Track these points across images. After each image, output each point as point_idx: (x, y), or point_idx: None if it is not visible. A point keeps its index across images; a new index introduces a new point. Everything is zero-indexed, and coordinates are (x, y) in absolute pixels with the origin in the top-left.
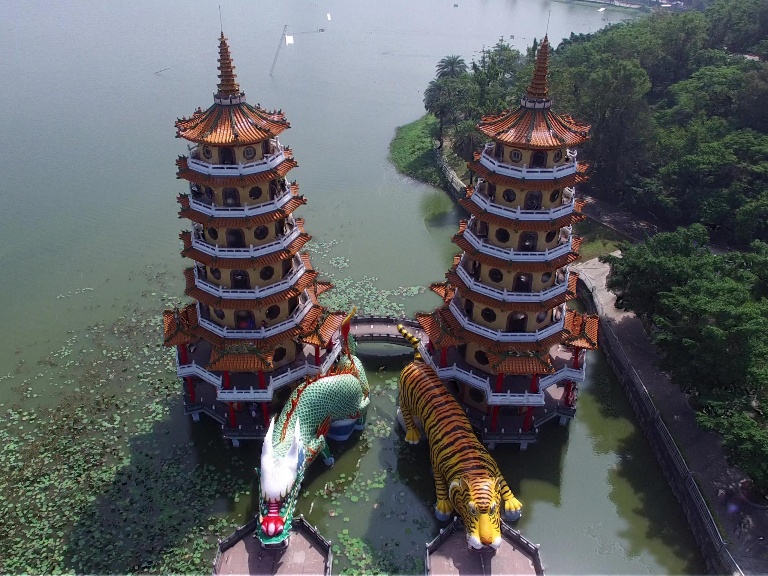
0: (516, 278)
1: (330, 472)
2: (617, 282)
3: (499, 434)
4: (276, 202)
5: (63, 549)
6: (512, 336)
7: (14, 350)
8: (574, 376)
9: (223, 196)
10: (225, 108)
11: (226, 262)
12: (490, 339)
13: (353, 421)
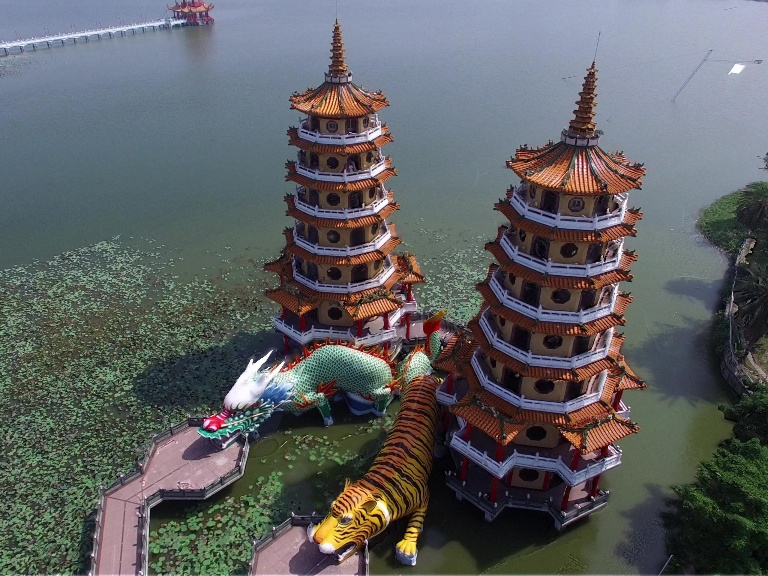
0: (516, 328)
1: (321, 429)
2: (731, 414)
3: (461, 485)
4: (345, 175)
5: (141, 372)
6: (497, 389)
7: (246, 246)
8: (566, 475)
9: (310, 158)
10: (328, 84)
11: (299, 214)
12: (479, 382)
13: (367, 401)
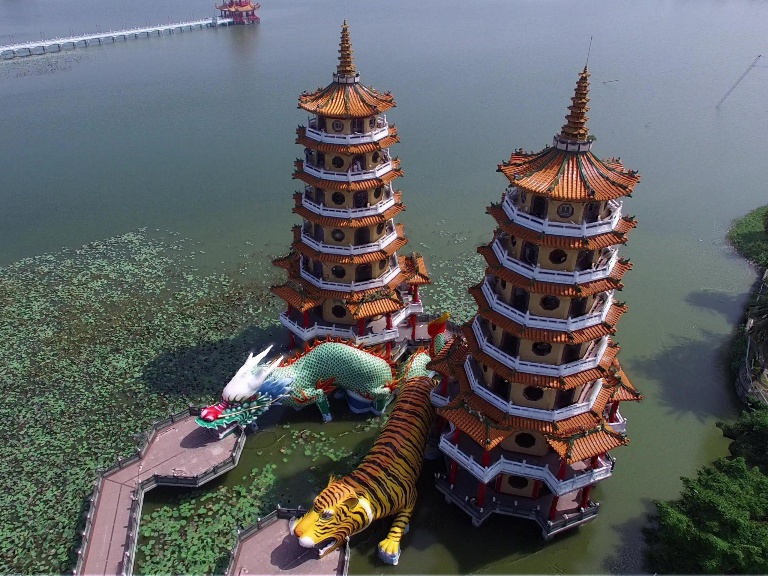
0: (506, 333)
1: (319, 425)
2: (729, 432)
3: (449, 488)
4: (349, 175)
5: (152, 360)
6: (487, 393)
7: (265, 242)
8: (552, 483)
9: (317, 157)
10: (335, 84)
11: (305, 211)
12: (470, 385)
13: (366, 400)
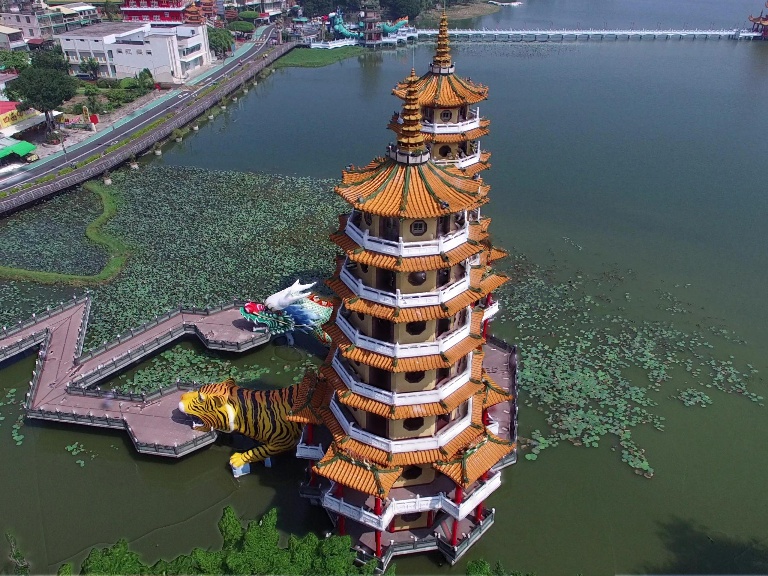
0: None
1: None
2: None
3: None
4: None
5: None
6: None
7: (489, 231)
8: None
9: None
10: None
11: None
12: None
13: None
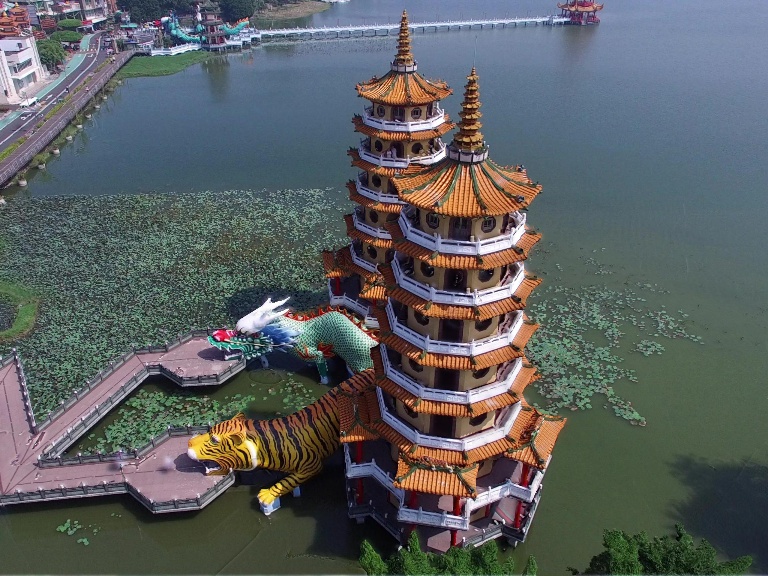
0: None
1: (315, 384)
2: None
3: None
4: (381, 159)
5: None
6: None
7: None
8: None
9: None
10: None
11: None
12: None
13: None
